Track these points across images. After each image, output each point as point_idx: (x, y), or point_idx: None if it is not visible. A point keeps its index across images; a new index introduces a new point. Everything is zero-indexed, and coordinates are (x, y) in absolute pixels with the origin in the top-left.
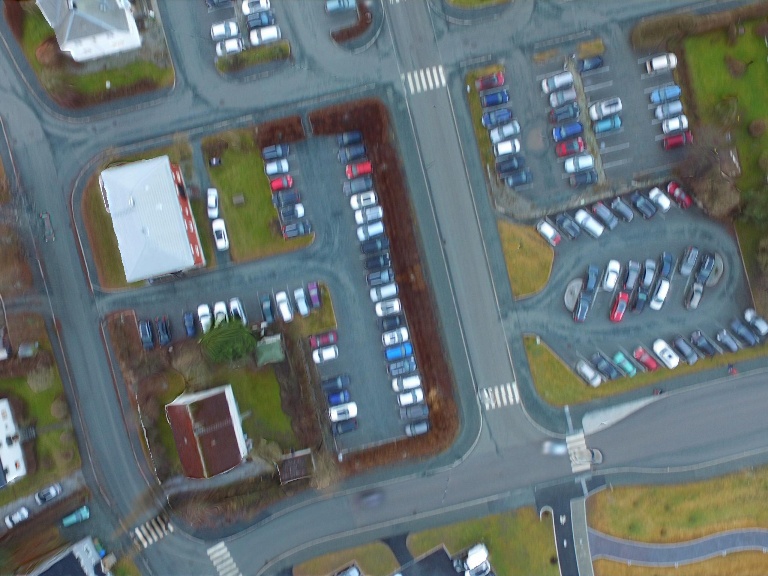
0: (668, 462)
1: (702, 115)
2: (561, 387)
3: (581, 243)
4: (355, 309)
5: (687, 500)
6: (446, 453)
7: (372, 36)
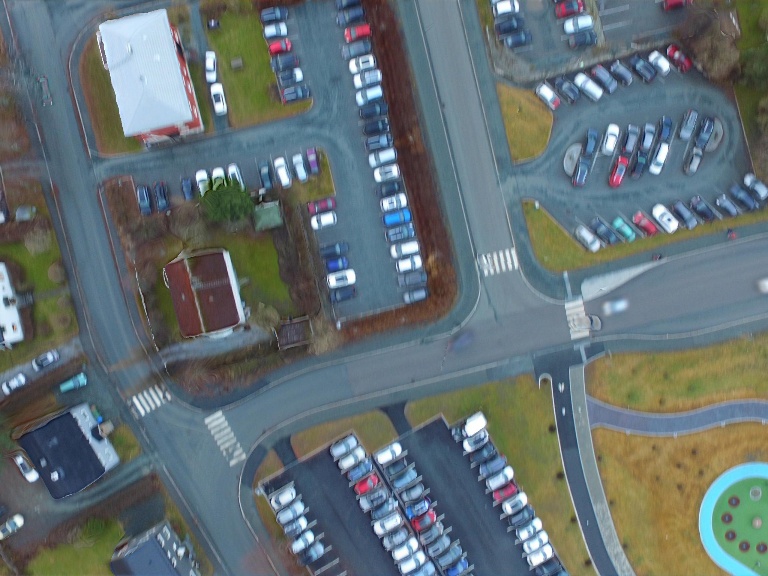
0: (667, 329)
1: None
2: (560, 252)
3: (580, 108)
4: (354, 176)
5: (686, 368)
6: (444, 320)
7: None
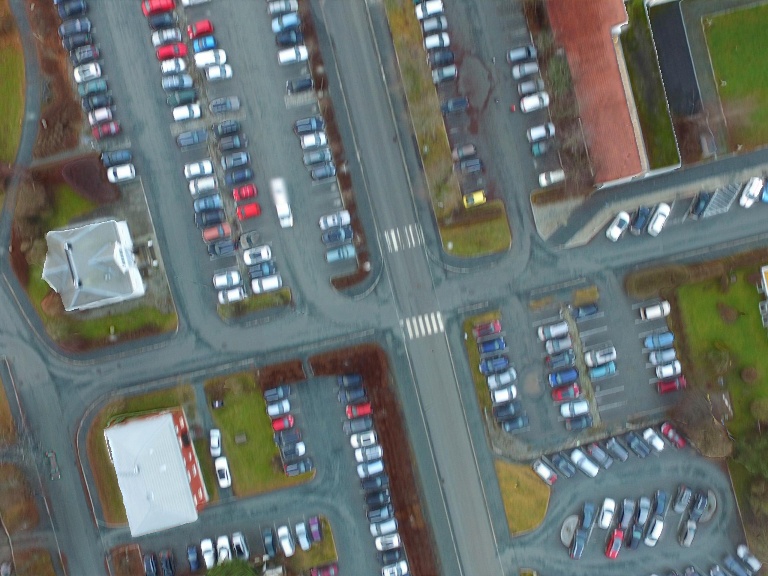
0: None
1: (695, 359)
2: None
3: (577, 480)
4: (355, 542)
5: None
6: None
7: (371, 283)
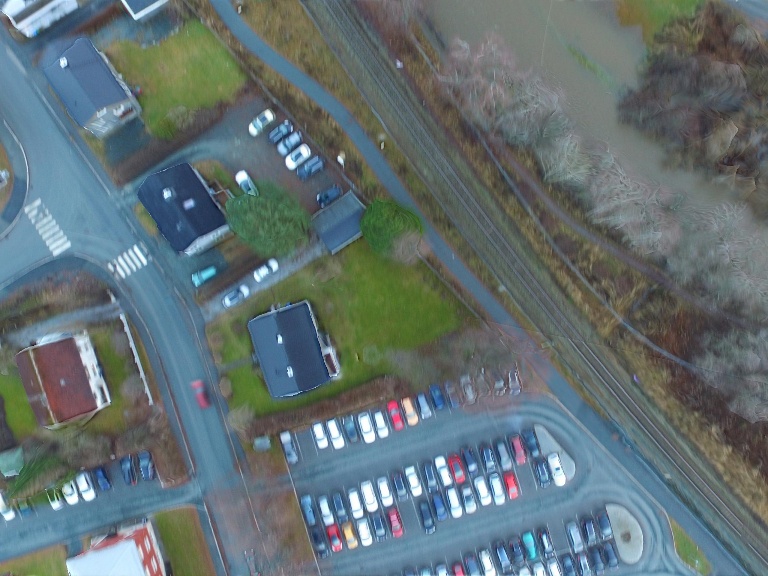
0: None
1: None
2: None
3: None
4: None
5: None
6: None
7: None
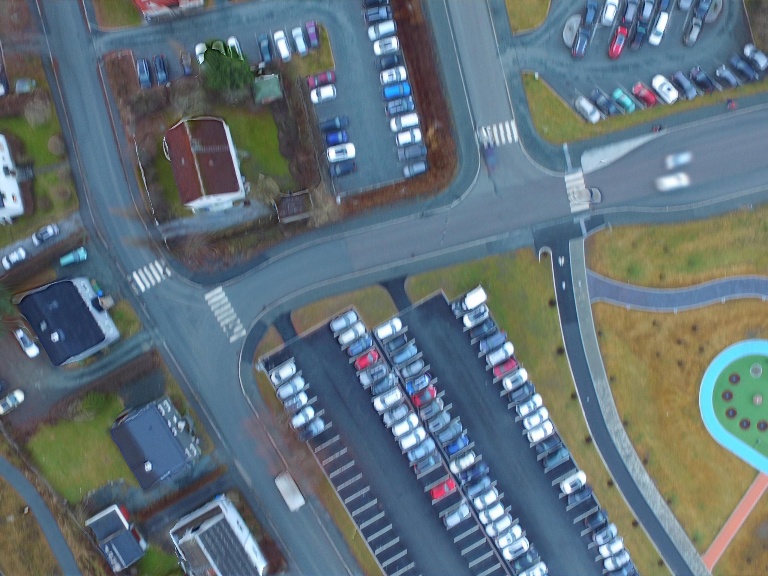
0: (667, 201)
1: None
2: (560, 124)
3: None
4: (353, 50)
5: (686, 241)
6: (444, 193)
7: None
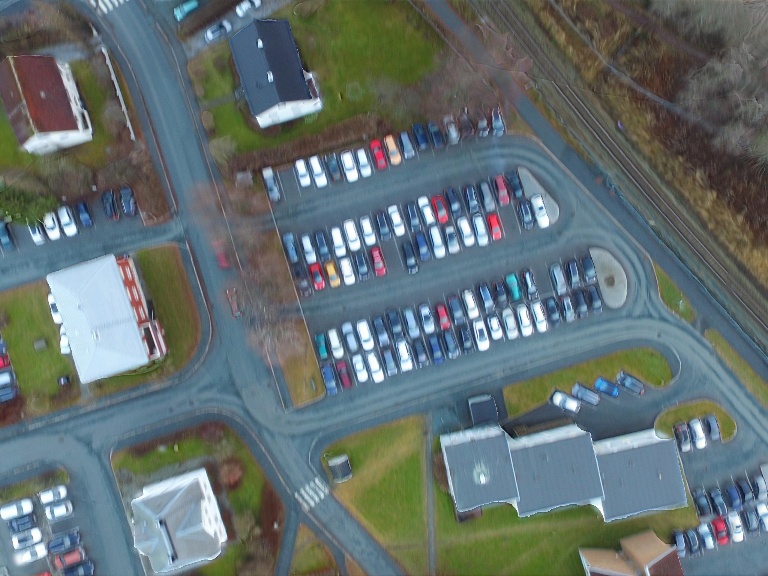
0: None
1: None
2: None
3: None
4: None
5: None
6: None
7: None
